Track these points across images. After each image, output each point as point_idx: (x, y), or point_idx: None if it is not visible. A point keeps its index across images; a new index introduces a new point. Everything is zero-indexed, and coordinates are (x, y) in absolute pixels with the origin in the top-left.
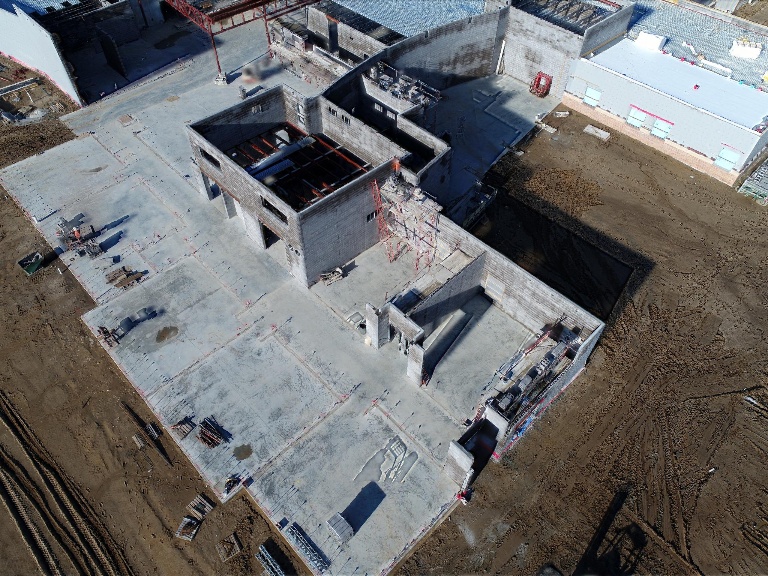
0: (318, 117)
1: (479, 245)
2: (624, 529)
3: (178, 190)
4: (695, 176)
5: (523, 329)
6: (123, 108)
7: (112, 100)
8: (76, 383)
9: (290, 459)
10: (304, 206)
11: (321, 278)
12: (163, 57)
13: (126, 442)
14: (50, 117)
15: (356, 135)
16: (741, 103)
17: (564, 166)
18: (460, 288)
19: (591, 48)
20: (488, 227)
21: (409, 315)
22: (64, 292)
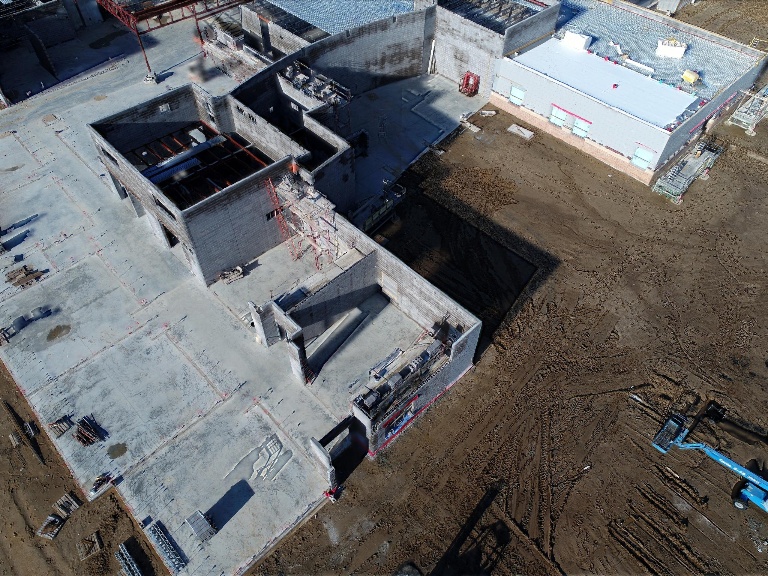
0: (229, 116)
1: (370, 243)
2: (490, 527)
3: (91, 189)
4: (613, 175)
5: (417, 327)
6: (48, 107)
7: (39, 99)
8: None
9: (163, 457)
10: None
11: (220, 277)
12: (97, 56)
13: (2, 441)
14: None
15: (262, 134)
16: (657, 102)
17: (483, 165)
18: (351, 286)
19: (515, 47)
20: (398, 226)
21: (289, 313)
22: None
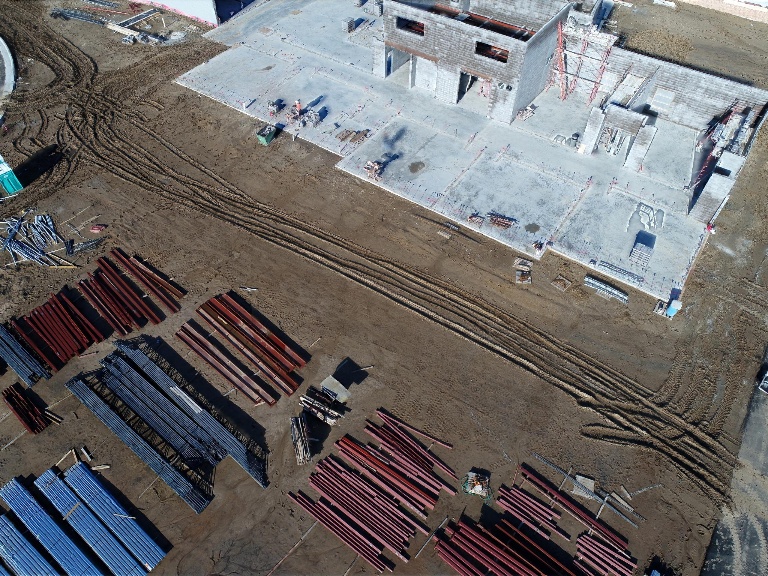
0: None
1: (653, 62)
2: None
3: (352, 74)
4: (754, 24)
5: (689, 129)
6: (256, 23)
7: (241, 18)
8: (364, 207)
9: (571, 226)
10: (494, 57)
11: (518, 115)
12: None
13: (434, 237)
14: (192, 36)
15: (512, 2)
16: None
17: (652, 28)
18: (643, 99)
19: None
20: None
21: None
22: (306, 152)
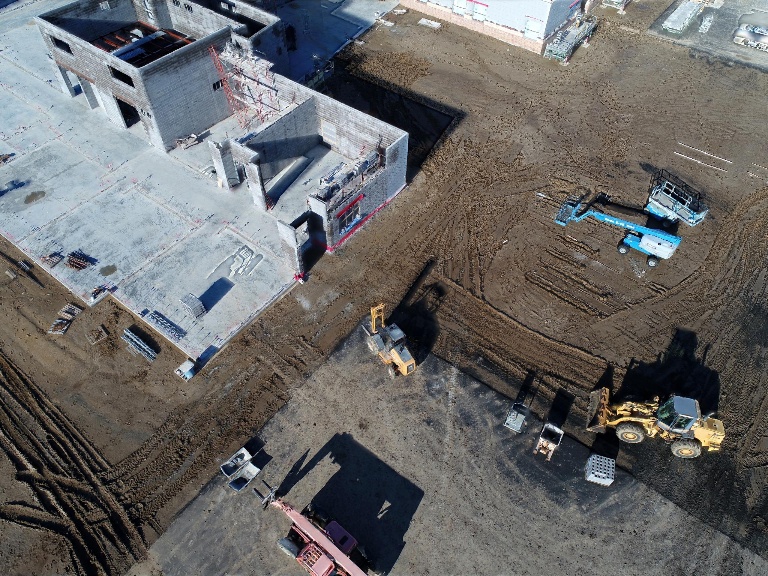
0: (165, 12)
1: (308, 92)
2: (432, 285)
3: (41, 92)
4: (511, 49)
5: None
6: None
7: None
8: None
9: (151, 270)
10: None
11: (177, 143)
12: None
13: None
14: None
15: (199, 21)
16: None
17: (400, 50)
18: (296, 131)
19: None
20: None
21: (245, 144)
22: None
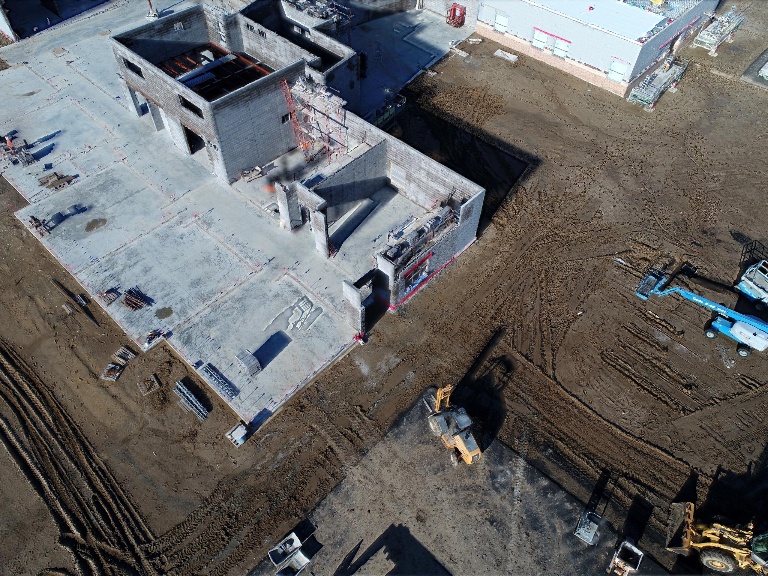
0: (238, 35)
1: (380, 134)
2: (500, 358)
3: (109, 109)
4: (591, 90)
5: (424, 212)
6: (56, 42)
7: (45, 35)
8: (9, 266)
9: (207, 316)
10: None
11: (241, 175)
12: None
13: (56, 310)
14: None
15: (272, 48)
16: (629, 21)
17: (473, 84)
18: (364, 174)
19: None
20: (399, 134)
21: (313, 189)
22: None
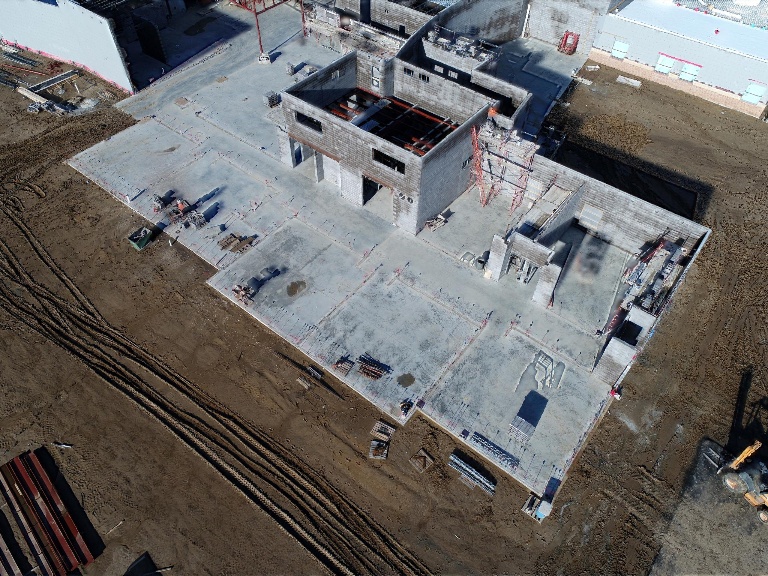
0: (391, 79)
1: (578, 177)
2: (758, 403)
3: (259, 161)
4: (725, 112)
5: (620, 251)
6: (175, 92)
7: (161, 85)
8: (224, 340)
9: (452, 381)
10: None
11: (426, 225)
12: (197, 42)
13: (292, 385)
14: (103, 105)
15: (434, 92)
16: (759, 43)
17: (609, 113)
18: (565, 218)
19: (615, 4)
20: None
21: (537, 240)
22: (180, 262)
